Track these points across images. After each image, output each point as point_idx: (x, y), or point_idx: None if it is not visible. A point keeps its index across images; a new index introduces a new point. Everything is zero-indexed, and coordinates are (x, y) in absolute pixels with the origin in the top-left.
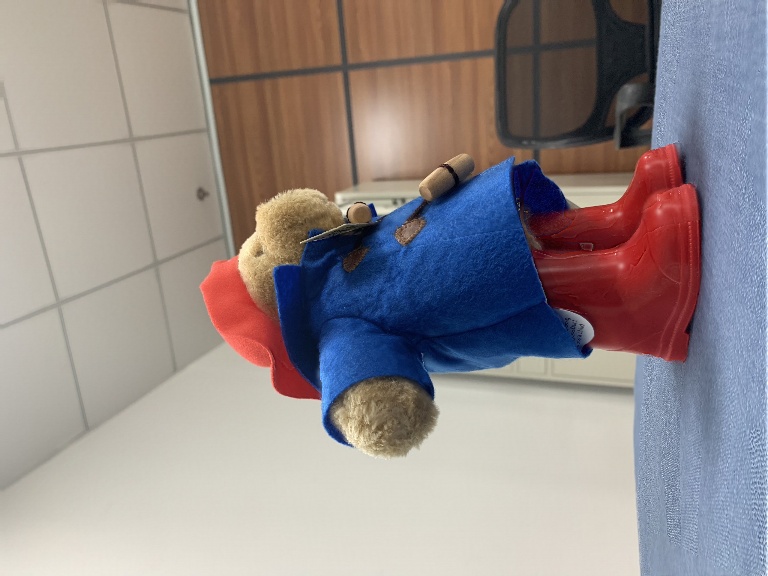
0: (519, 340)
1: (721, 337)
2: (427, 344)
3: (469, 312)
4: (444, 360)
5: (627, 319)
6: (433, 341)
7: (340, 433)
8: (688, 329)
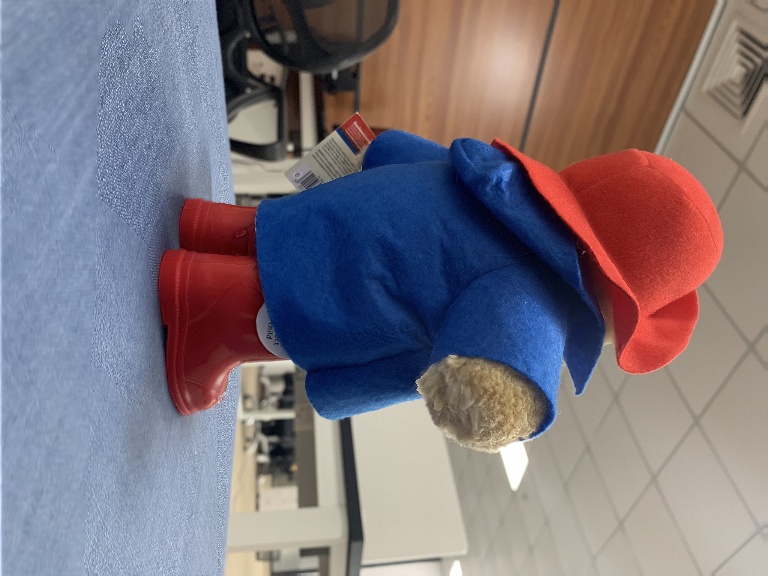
0: (331, 352)
1: (149, 515)
2: (433, 342)
3: (379, 387)
4: (419, 311)
5: (226, 333)
6: (425, 344)
7: (541, 395)
8: (166, 330)
